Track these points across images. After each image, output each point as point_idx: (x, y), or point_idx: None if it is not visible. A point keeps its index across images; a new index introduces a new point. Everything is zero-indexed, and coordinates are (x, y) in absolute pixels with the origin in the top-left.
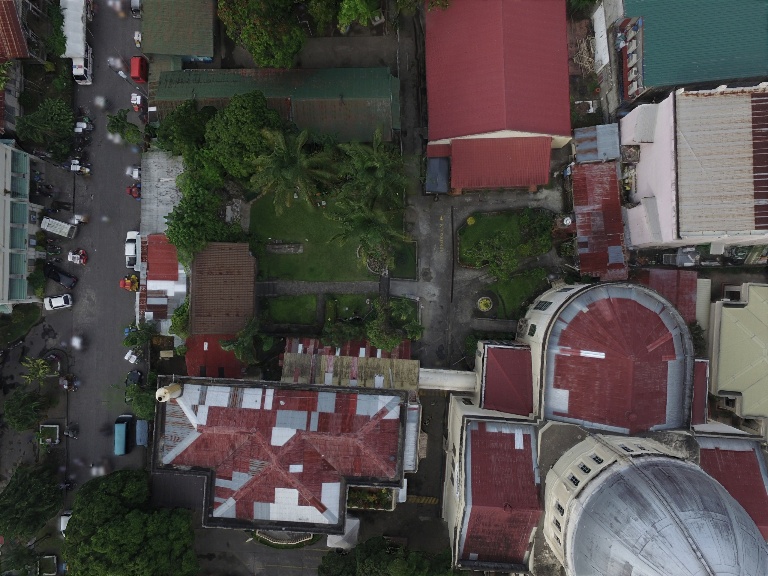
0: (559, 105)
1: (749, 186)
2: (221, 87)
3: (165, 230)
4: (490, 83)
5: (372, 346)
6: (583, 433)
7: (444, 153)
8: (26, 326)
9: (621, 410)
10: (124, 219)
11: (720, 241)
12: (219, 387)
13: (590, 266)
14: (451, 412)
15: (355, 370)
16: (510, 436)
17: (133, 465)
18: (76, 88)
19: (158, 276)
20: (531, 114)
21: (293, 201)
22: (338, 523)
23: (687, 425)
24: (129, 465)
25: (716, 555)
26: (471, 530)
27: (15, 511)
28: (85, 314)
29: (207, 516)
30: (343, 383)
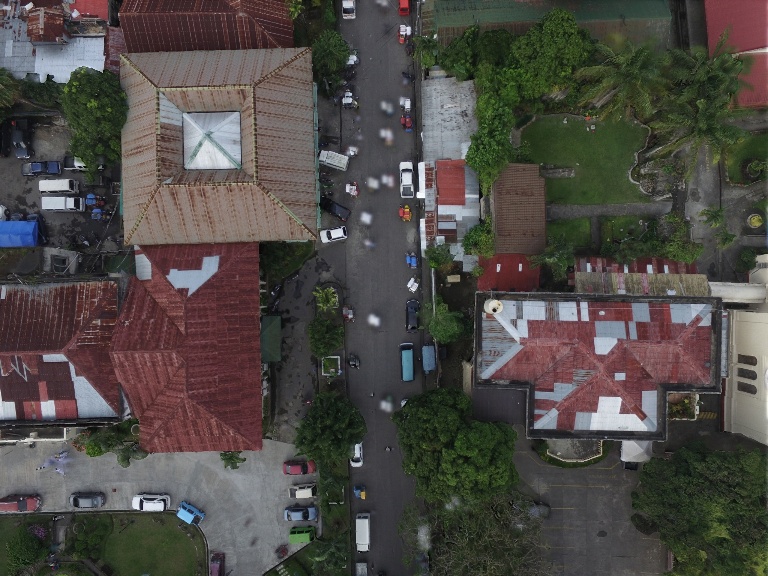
0: None
1: None
2: (500, 13)
3: (469, 151)
4: None
5: (658, 263)
6: None
7: None
8: (300, 260)
9: None
10: (392, 151)
11: None
12: (534, 302)
13: None
14: (734, 326)
15: (646, 286)
16: None
17: (414, 393)
18: (338, 23)
19: (447, 201)
20: None
21: (562, 126)
22: (656, 430)
23: None
24: (410, 393)
25: None
26: None
27: (332, 433)
28: (358, 246)
29: (529, 428)
30: None
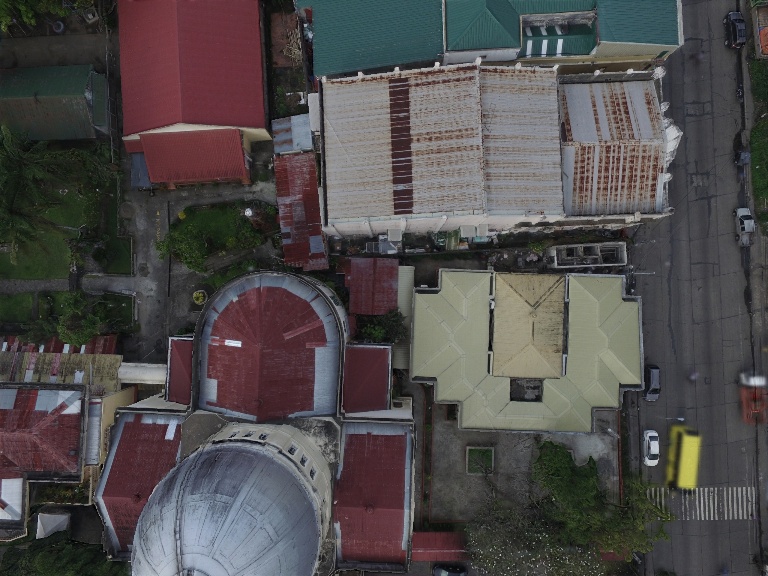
0: (250, 97)
1: (388, 171)
2: None
3: None
4: (169, 77)
5: None
6: (222, 422)
7: None
8: None
9: (251, 398)
10: None
11: (391, 227)
12: None
13: (293, 256)
14: None
15: (56, 366)
16: (163, 427)
17: None
18: None
19: None
20: (214, 107)
21: None
22: (21, 519)
23: (336, 411)
24: None
25: (193, 536)
26: (115, 521)
27: None
28: None
29: None
30: (43, 380)
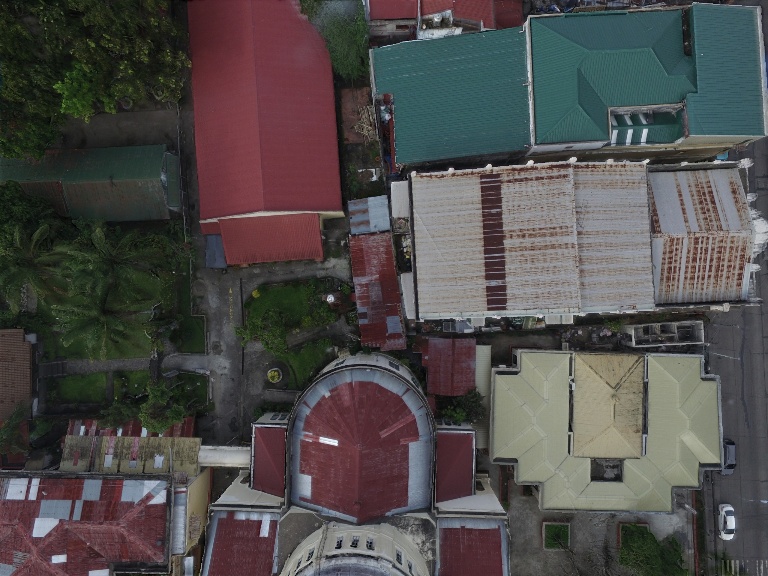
0: (327, 179)
1: (480, 267)
2: None
3: None
4: (249, 163)
5: None
6: (319, 521)
7: (219, 230)
8: None
9: (350, 499)
10: None
11: None
12: None
13: (370, 336)
14: None
15: (136, 451)
16: (257, 523)
17: None
18: None
19: None
20: (294, 192)
21: None
22: None
23: (430, 506)
24: None
25: None
26: None
27: None
28: None
29: None
30: (122, 465)
